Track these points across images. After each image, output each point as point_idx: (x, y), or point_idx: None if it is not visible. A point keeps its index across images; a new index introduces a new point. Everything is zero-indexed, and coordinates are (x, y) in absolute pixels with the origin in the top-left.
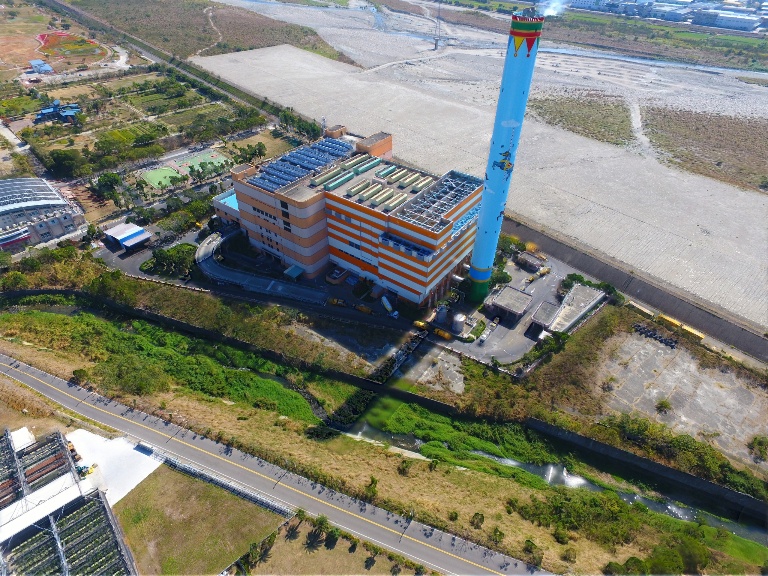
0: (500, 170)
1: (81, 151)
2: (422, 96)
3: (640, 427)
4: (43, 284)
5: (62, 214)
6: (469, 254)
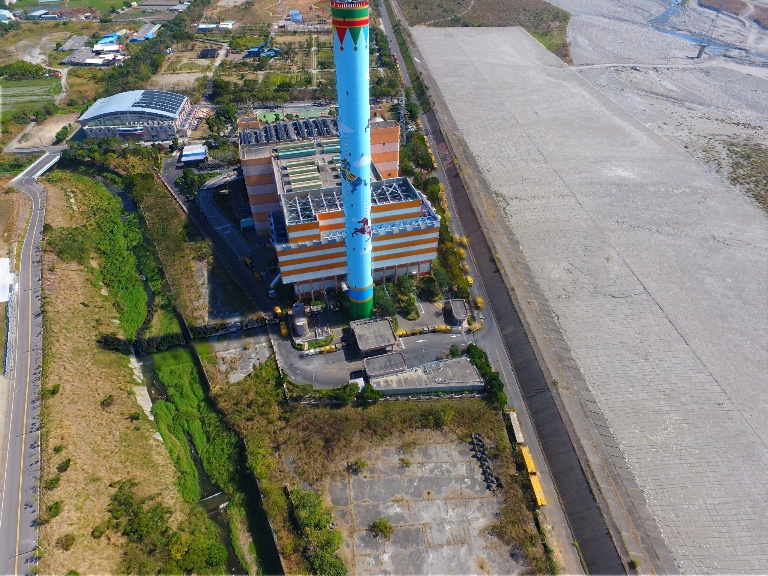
0: (343, 179)
1: (233, 84)
2: (596, 106)
3: (306, 519)
4: (118, 168)
5: (168, 124)
6: (383, 271)
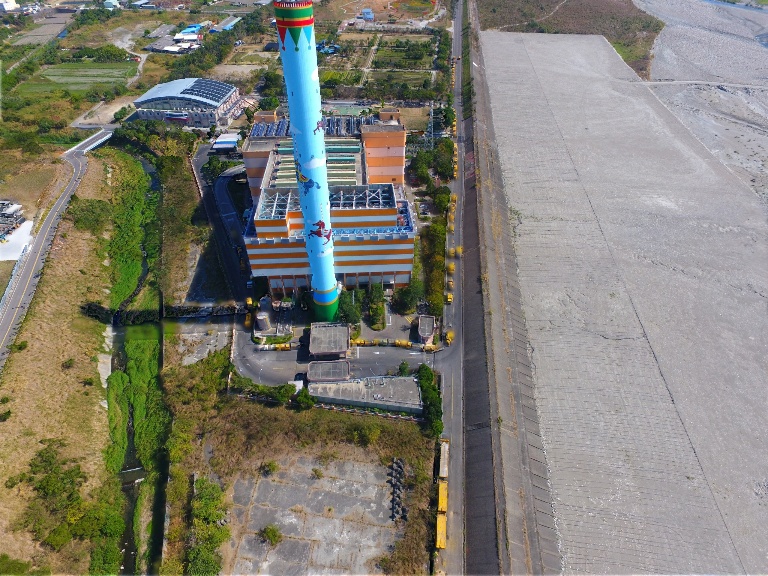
0: None
1: (283, 78)
2: (658, 127)
3: (197, 510)
4: (157, 149)
5: (210, 112)
6: (356, 277)
